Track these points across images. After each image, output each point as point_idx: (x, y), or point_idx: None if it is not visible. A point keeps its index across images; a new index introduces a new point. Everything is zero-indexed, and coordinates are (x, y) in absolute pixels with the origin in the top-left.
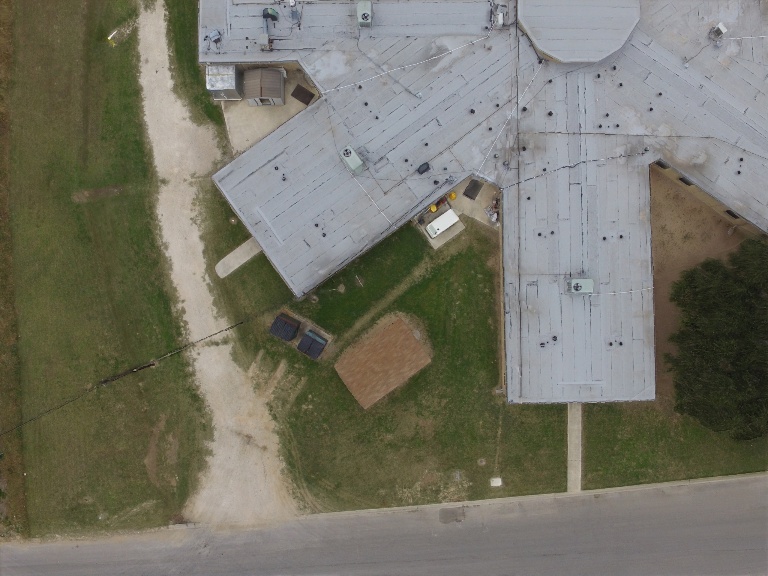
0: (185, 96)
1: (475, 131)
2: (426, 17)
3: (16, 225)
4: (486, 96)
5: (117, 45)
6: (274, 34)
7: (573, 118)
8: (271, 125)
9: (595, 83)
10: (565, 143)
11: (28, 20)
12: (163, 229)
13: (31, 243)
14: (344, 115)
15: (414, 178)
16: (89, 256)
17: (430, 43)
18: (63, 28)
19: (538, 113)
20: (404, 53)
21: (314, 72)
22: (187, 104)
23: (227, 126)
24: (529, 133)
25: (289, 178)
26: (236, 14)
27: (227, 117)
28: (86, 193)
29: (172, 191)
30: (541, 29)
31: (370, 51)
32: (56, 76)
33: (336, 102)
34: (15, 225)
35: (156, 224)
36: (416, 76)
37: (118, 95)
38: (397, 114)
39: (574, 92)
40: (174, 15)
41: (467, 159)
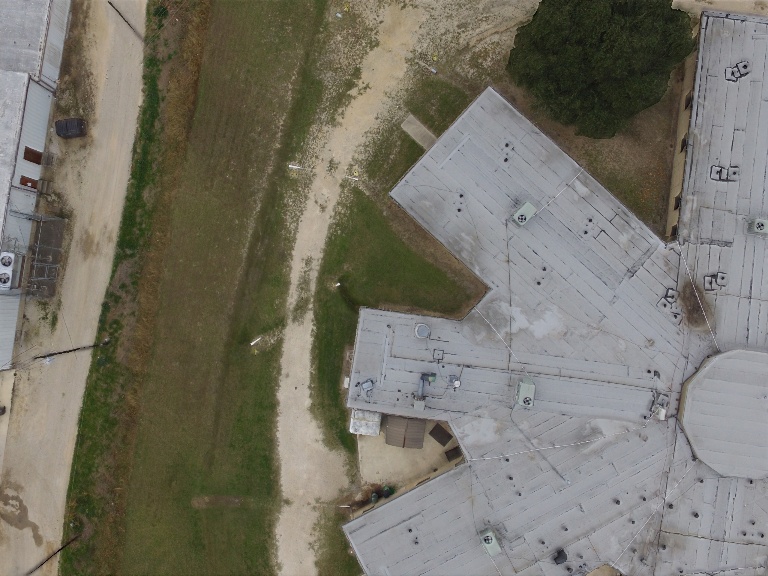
0: (321, 417)
1: (617, 521)
2: (585, 398)
3: (132, 520)
4: (633, 487)
5: (259, 353)
6: (428, 392)
7: (719, 524)
8: (404, 461)
9: (746, 488)
10: (707, 548)
11: (172, 312)
12: (280, 549)
13: (144, 541)
14: (486, 485)
15: (548, 561)
16: (201, 563)
17: (585, 424)
18: (207, 326)
19: (683, 511)
20: (557, 430)
21: (462, 436)
22: (322, 426)
23: (359, 455)
24: (672, 533)
25: (421, 542)
26: (393, 367)
27: (361, 446)
28: (206, 498)
29: (294, 513)
30: (704, 439)
31: (522, 422)
32: (193, 375)
33: (480, 470)
34: (131, 520)
35: (273, 543)
36: (565, 456)
37: (253, 405)
38: (541, 493)
39: (724, 498)
40: (322, 331)
41: (604, 548)
